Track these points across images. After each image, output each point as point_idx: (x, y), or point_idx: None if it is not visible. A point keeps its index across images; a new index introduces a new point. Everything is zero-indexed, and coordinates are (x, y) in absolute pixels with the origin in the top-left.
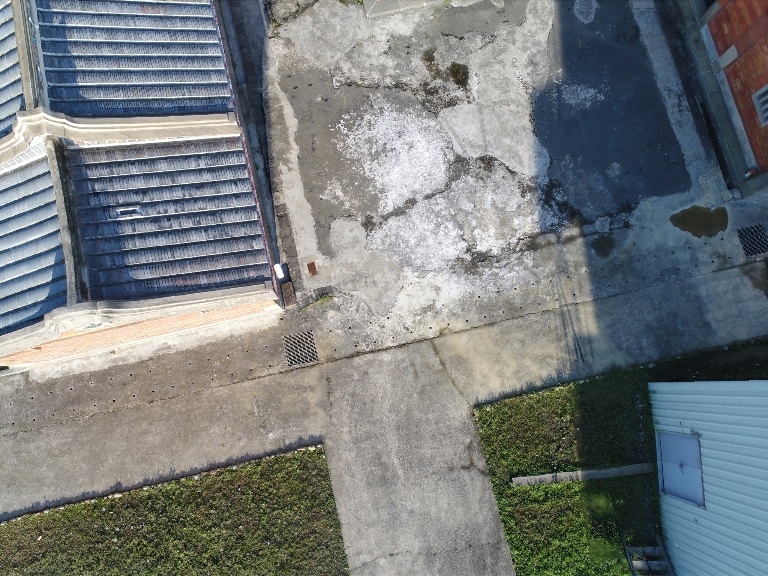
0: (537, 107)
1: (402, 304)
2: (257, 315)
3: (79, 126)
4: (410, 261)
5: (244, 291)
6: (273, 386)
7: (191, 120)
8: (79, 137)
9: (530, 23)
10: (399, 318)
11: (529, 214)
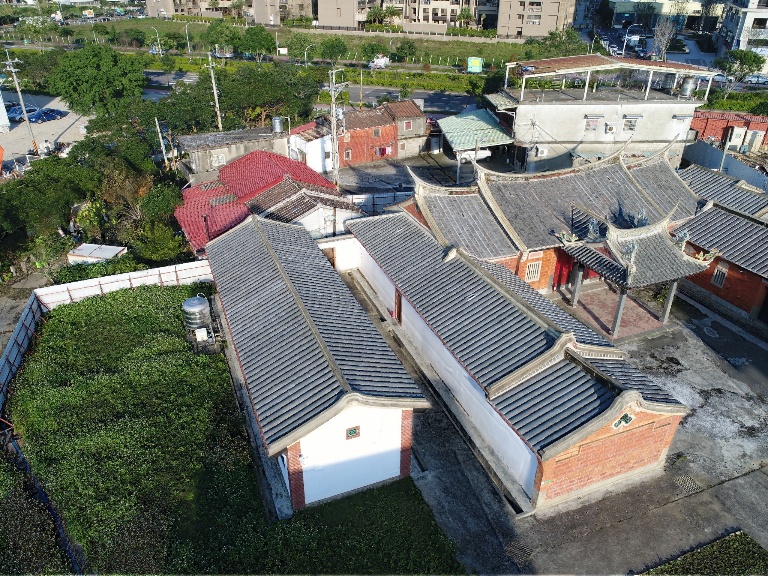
0: (723, 368)
1: (727, 455)
2: (652, 468)
3: (577, 344)
4: (715, 435)
5: (678, 405)
6: (687, 504)
7: (609, 348)
8: (578, 348)
9: (691, 340)
10: (731, 462)
11: (759, 408)
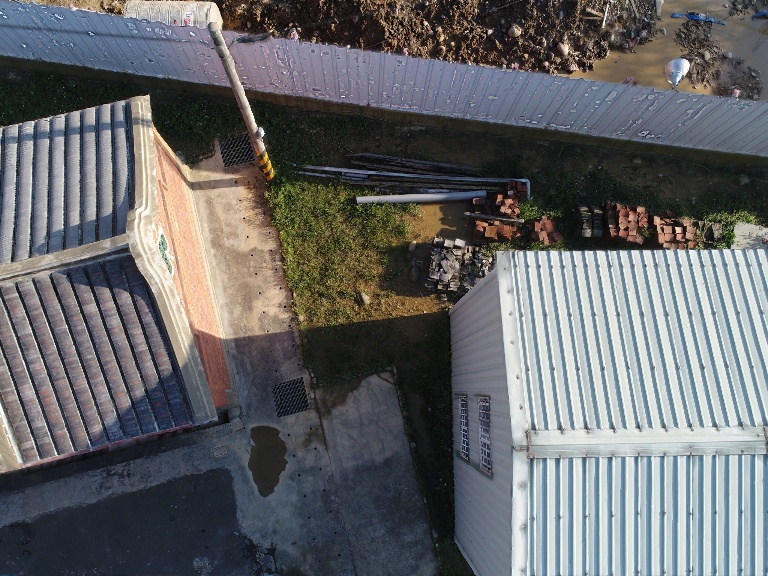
0: None
1: None
2: None
3: None
4: None
5: None
6: None
7: None
8: None
9: None
10: None
11: None
